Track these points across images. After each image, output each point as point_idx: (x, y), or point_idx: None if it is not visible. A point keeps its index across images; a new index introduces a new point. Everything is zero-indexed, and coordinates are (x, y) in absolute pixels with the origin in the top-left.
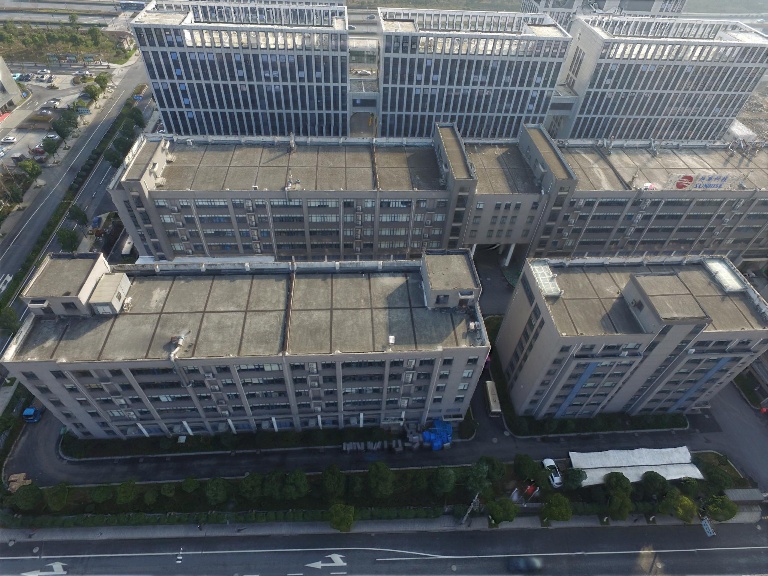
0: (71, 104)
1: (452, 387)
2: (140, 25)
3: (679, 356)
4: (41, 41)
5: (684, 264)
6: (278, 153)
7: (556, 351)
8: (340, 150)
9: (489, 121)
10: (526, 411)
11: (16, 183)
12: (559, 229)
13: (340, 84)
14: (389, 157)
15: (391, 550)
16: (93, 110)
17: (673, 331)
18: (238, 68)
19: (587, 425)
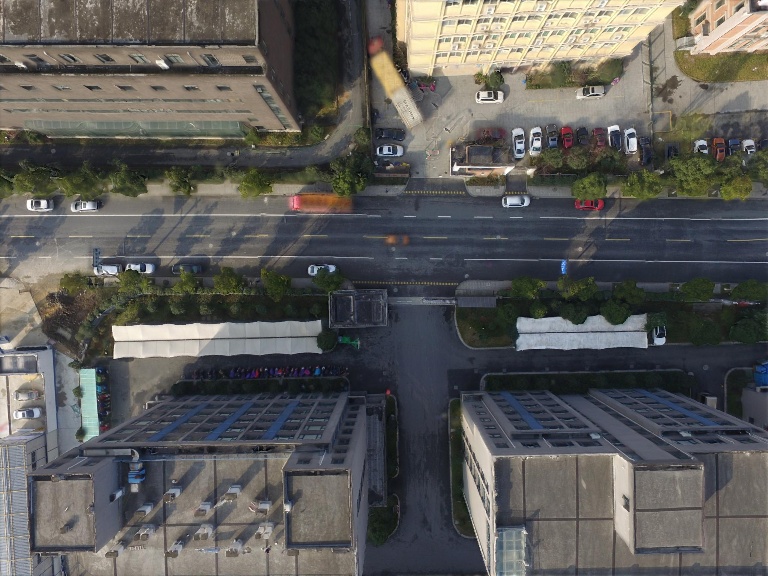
0: None
1: None
2: None
3: None
4: None
5: None
6: None
7: None
8: None
9: None
10: None
11: None
12: None
13: None
14: None
15: None
16: None
17: None
18: None
19: None
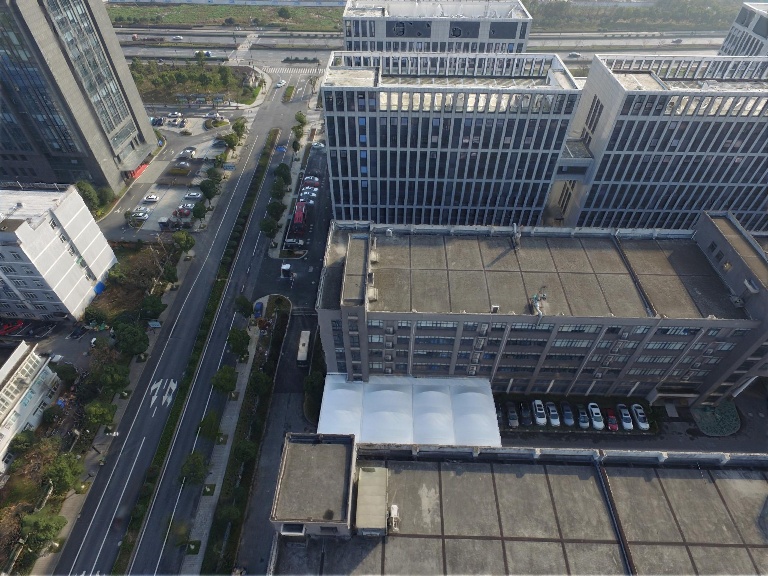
0: (207, 153)
1: None
2: (331, 88)
3: None
4: (170, 81)
5: None
6: (500, 249)
7: None
8: (575, 245)
9: (727, 192)
10: None
11: (166, 255)
12: None
13: (551, 151)
14: (644, 257)
15: None
16: (230, 160)
17: None
18: (433, 134)
19: None
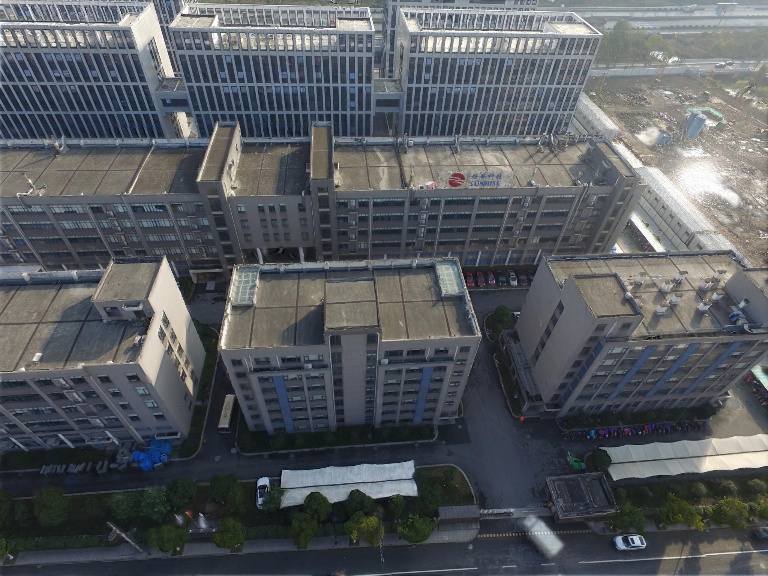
0: None
1: (138, 405)
2: None
3: (377, 367)
4: None
5: (415, 267)
6: (42, 157)
7: (229, 365)
8: (114, 152)
9: (313, 119)
10: (257, 426)
11: None
12: (344, 231)
13: (140, 83)
14: (163, 159)
15: None
16: None
17: (346, 341)
18: (23, 68)
19: (323, 439)
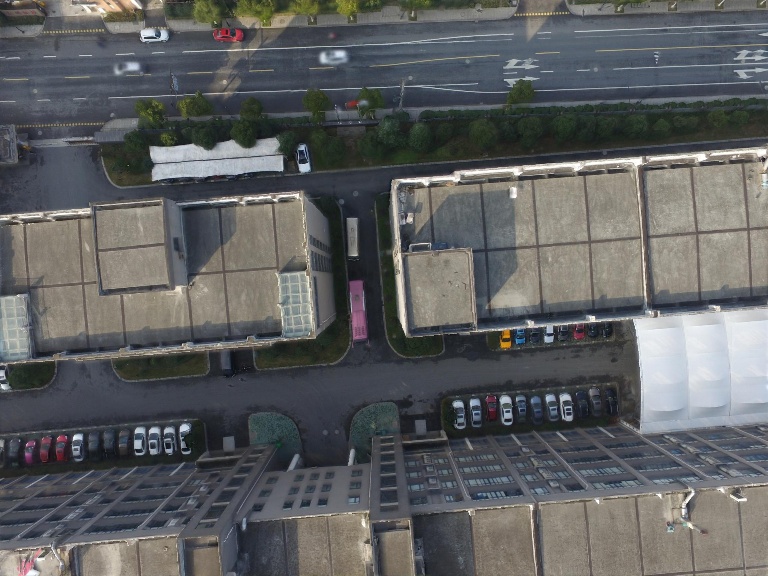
0: None
1: None
2: None
3: None
4: None
5: None
6: None
7: None
8: None
9: None
10: None
11: None
12: None
13: None
14: None
15: (465, 91)
16: None
17: None
18: None
19: None
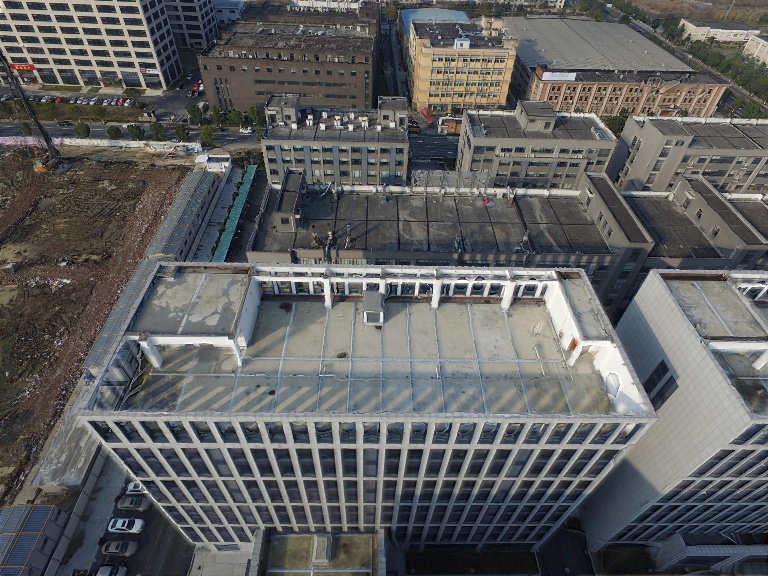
0: None
1: None
2: None
3: None
4: None
5: None
6: None
7: None
8: None
9: None
10: None
11: None
12: None
13: None
14: None
15: None
16: None
17: None
18: None
19: None
